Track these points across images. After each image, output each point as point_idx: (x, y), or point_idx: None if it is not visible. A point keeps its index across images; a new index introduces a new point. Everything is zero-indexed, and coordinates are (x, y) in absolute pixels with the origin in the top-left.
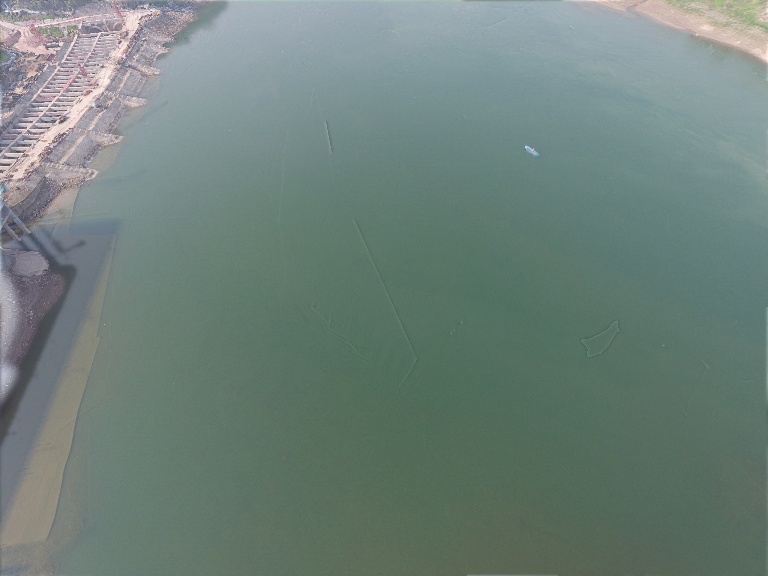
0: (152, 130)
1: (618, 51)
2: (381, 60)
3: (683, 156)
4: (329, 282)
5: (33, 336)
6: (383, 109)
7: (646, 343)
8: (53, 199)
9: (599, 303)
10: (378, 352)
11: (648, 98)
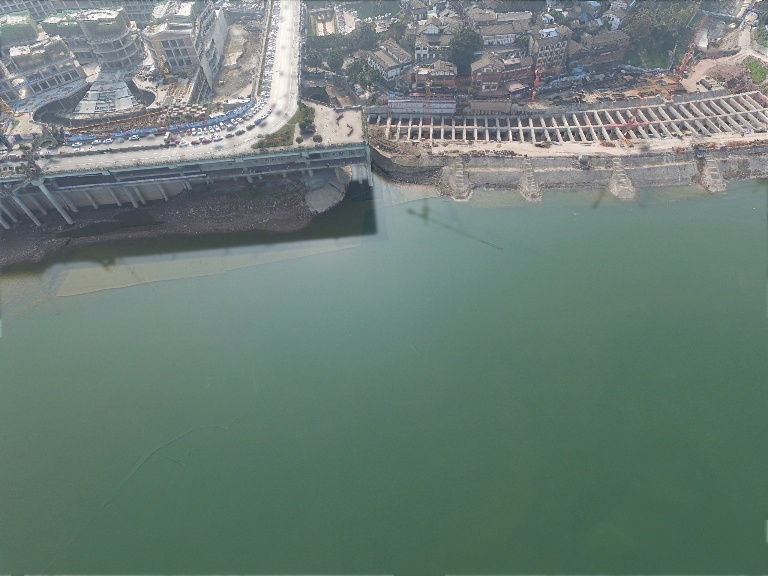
0: (560, 223)
1: None
2: None
3: None
4: None
5: (241, 230)
6: None
7: None
8: (419, 184)
9: None
10: (47, 554)
11: None
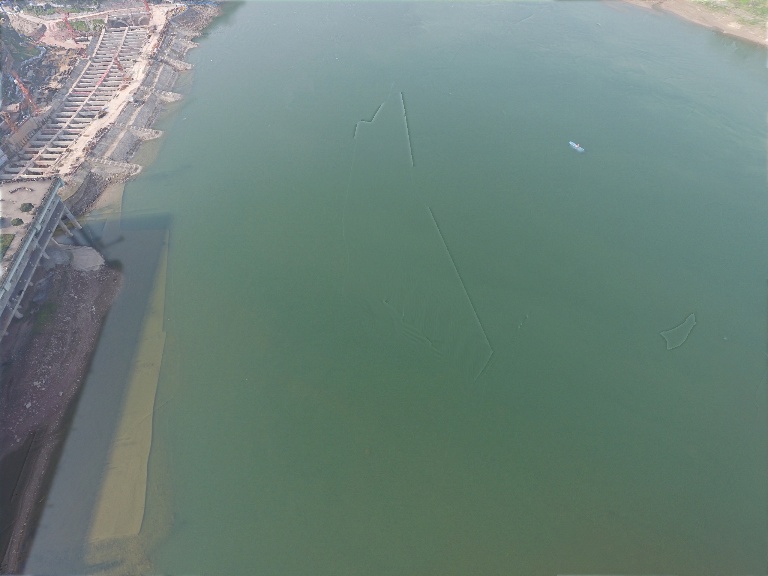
0: (191, 125)
1: (648, 48)
2: (414, 56)
3: (724, 152)
4: (402, 276)
5: (98, 331)
6: (421, 105)
7: (708, 336)
8: (100, 194)
9: (659, 297)
10: (453, 346)
11: (683, 95)
